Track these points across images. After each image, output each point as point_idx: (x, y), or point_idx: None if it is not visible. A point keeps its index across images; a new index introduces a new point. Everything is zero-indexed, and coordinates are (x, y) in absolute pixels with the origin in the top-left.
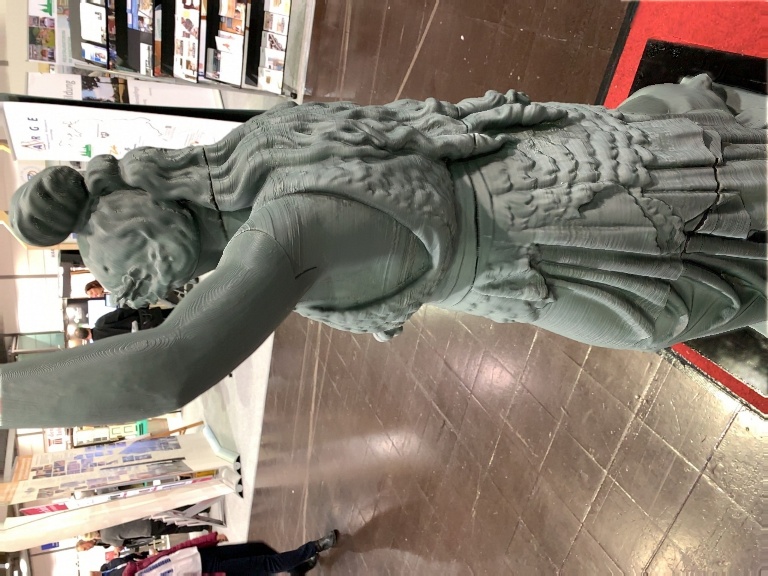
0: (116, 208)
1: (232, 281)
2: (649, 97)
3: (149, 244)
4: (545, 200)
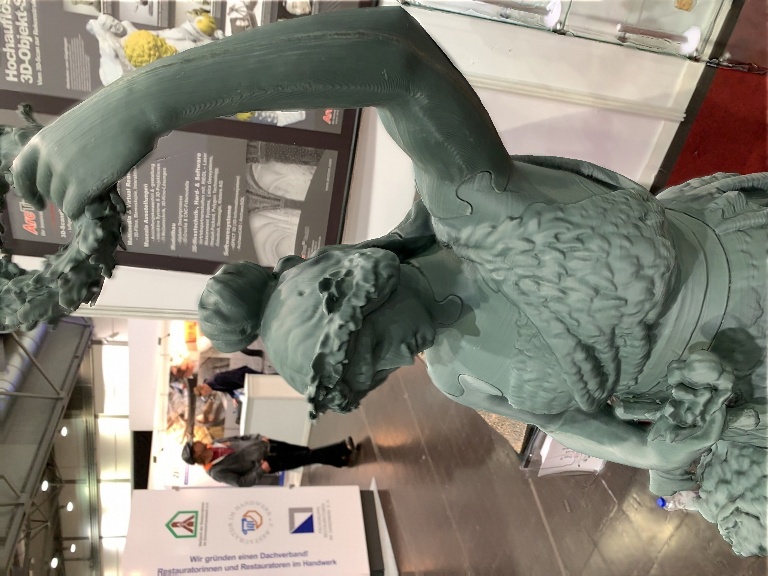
0: None
1: None
2: None
3: (343, 260)
4: None
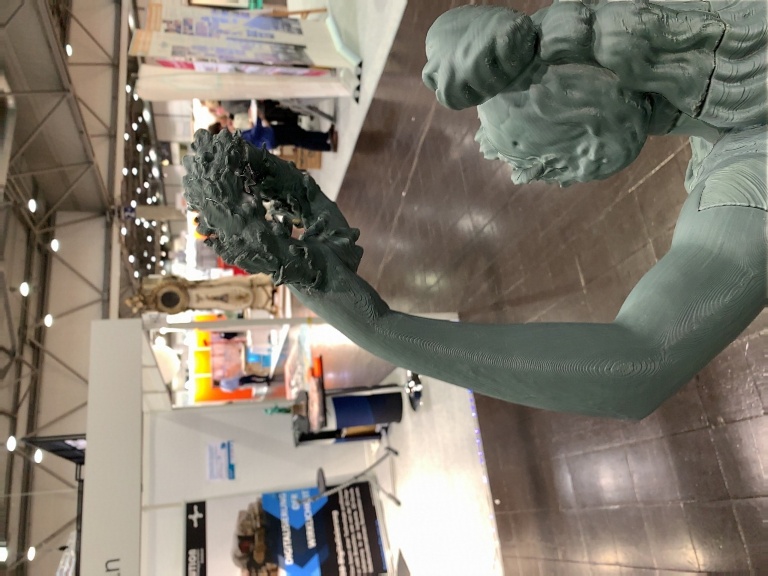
0: (567, 87)
1: (732, 292)
2: None
3: (586, 138)
4: None
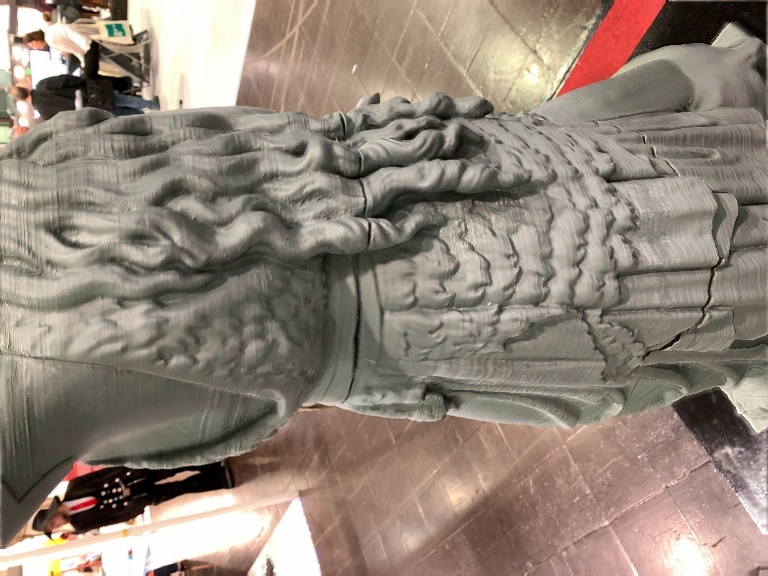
0: None
1: None
2: (673, 68)
3: None
4: (458, 331)
